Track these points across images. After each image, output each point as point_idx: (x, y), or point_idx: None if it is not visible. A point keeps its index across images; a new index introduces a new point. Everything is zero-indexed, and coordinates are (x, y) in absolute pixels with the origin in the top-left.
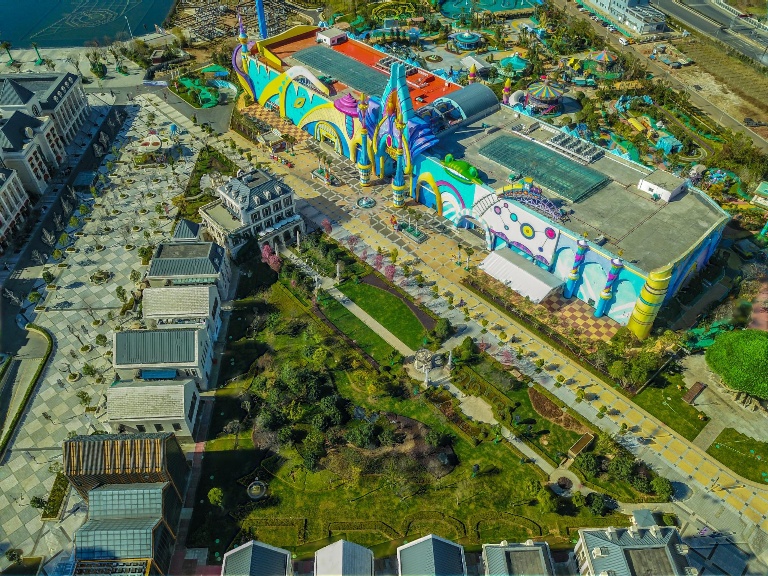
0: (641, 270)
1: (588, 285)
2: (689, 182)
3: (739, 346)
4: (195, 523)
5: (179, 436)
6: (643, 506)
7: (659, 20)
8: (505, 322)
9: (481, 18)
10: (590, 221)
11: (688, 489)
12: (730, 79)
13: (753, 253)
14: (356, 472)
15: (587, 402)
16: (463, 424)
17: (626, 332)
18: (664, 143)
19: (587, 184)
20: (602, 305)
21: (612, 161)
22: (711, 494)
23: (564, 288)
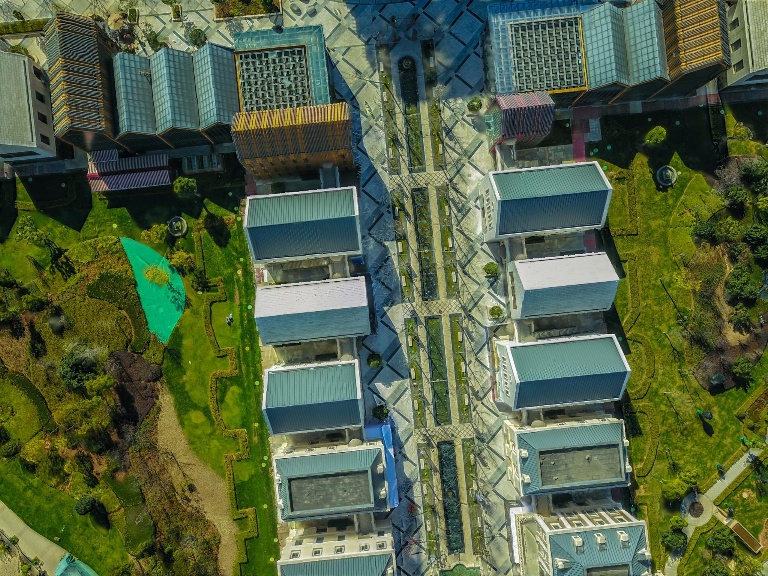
0: None
1: None
2: None
3: None
4: (626, 119)
5: (727, 71)
6: None
7: None
8: None
9: None
10: None
11: None
12: None
13: None
14: (695, 285)
15: None
16: (764, 402)
17: None
18: None
19: None
20: None
21: None
22: None
23: None
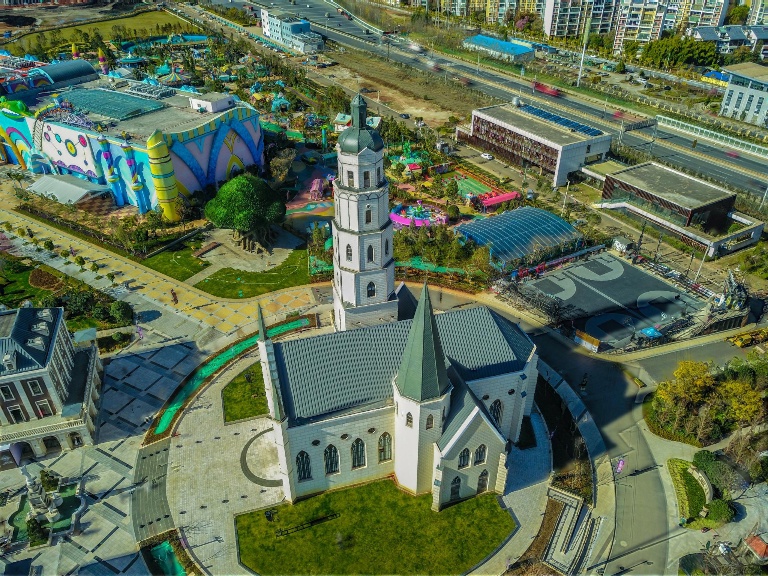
0: (144, 146)
1: (129, 186)
2: (235, 97)
3: (221, 189)
4: None
5: None
6: (101, 332)
7: (318, 41)
8: (41, 229)
9: (153, 48)
10: (127, 129)
11: (158, 314)
12: (361, 69)
13: (316, 159)
14: None
15: (91, 270)
16: None
17: (152, 213)
18: (274, 104)
19: (138, 106)
20: (139, 199)
21: (181, 97)
22: (179, 313)
23: (114, 196)
